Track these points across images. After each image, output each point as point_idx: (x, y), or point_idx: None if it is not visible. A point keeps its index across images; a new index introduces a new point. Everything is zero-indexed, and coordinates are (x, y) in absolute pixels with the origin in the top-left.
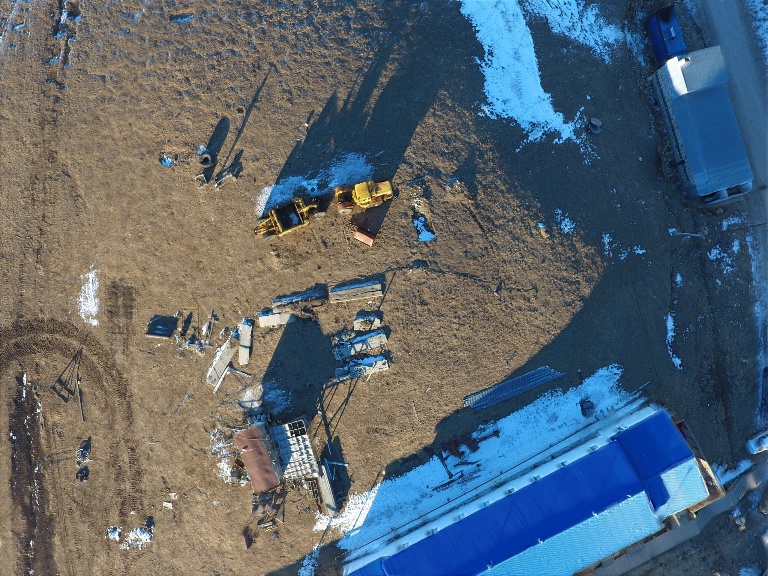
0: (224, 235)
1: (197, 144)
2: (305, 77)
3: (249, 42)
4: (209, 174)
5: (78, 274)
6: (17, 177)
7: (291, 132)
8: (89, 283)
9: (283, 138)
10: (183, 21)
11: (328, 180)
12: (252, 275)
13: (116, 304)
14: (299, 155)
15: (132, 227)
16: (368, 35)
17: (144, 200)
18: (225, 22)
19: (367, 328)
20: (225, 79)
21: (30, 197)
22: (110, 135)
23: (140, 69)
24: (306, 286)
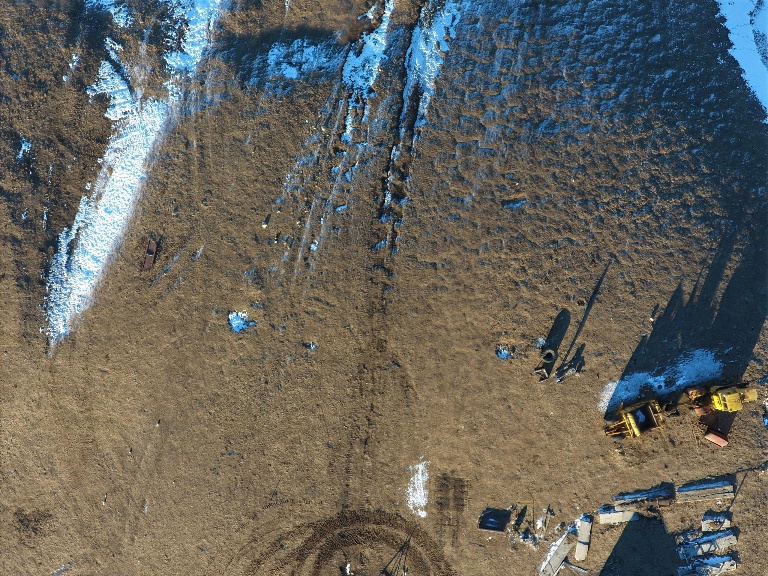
0: (564, 430)
1: (536, 337)
2: (648, 269)
3: (587, 231)
4: (549, 368)
5: (407, 465)
6: (344, 366)
7: (636, 327)
8: (418, 474)
9: (627, 333)
10: (516, 207)
11: (676, 377)
12: (593, 471)
13: (446, 496)
14: (645, 351)
15: (466, 419)
16: (710, 224)
17: (479, 392)
18: (560, 209)
19: (716, 529)
20: (564, 270)
21: (358, 386)
22: (443, 325)
23: (473, 257)
24: (651, 484)
